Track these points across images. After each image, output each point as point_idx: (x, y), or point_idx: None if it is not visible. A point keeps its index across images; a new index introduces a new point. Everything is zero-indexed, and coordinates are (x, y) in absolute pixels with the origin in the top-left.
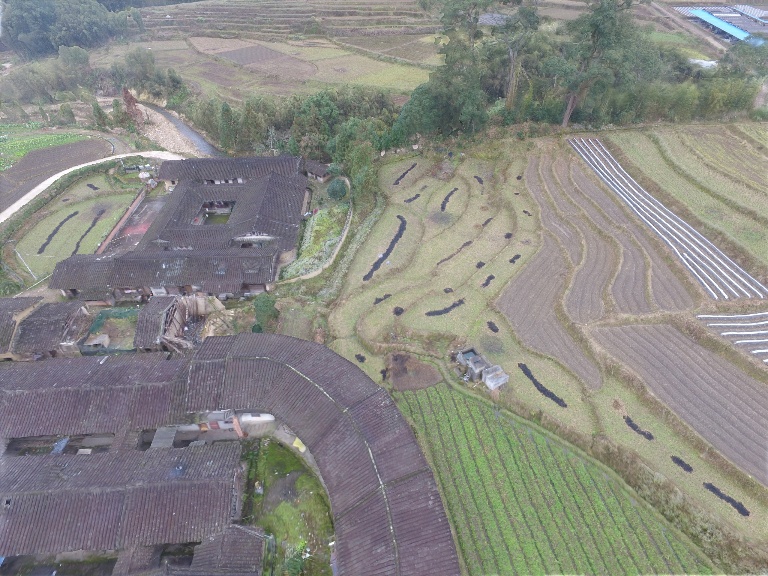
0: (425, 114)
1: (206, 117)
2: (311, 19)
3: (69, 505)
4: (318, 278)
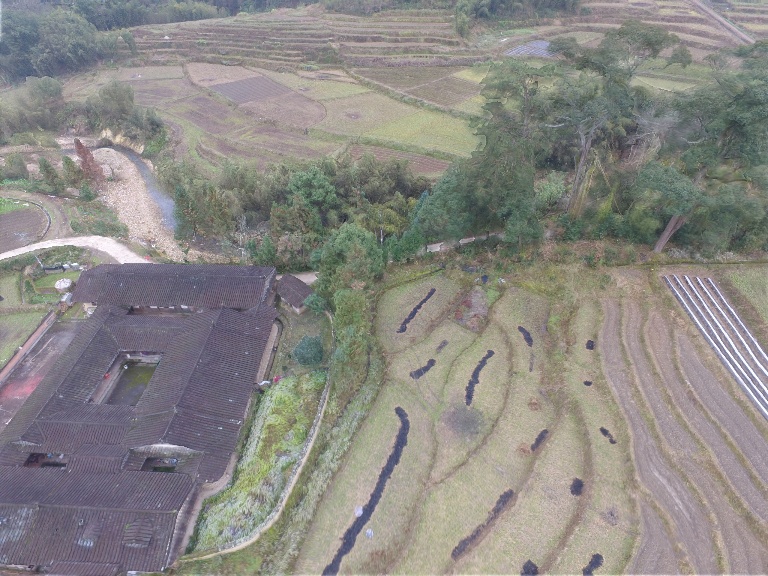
0: (451, 219)
1: (171, 186)
2: (327, 45)
3: None
4: (251, 551)
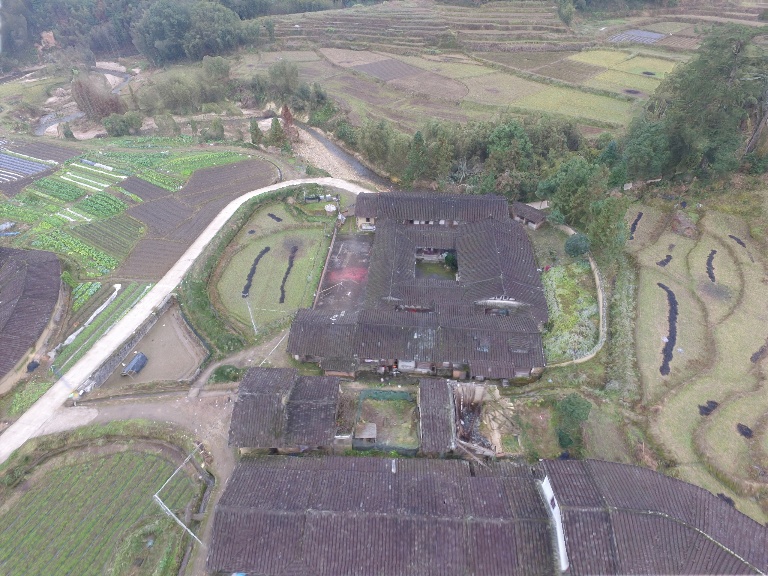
0: (656, 156)
1: (374, 141)
2: (446, 32)
3: None
4: (593, 363)
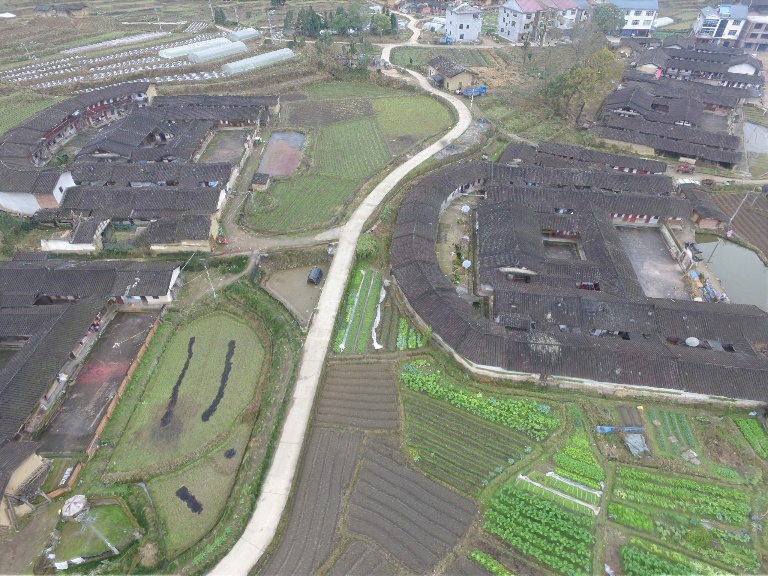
0: None
1: None
2: None
3: None
4: None
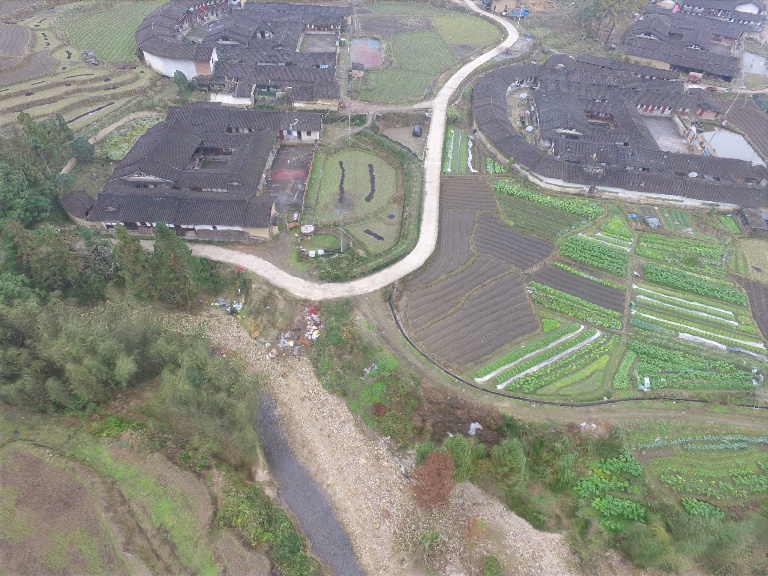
0: None
1: None
2: None
3: None
4: None
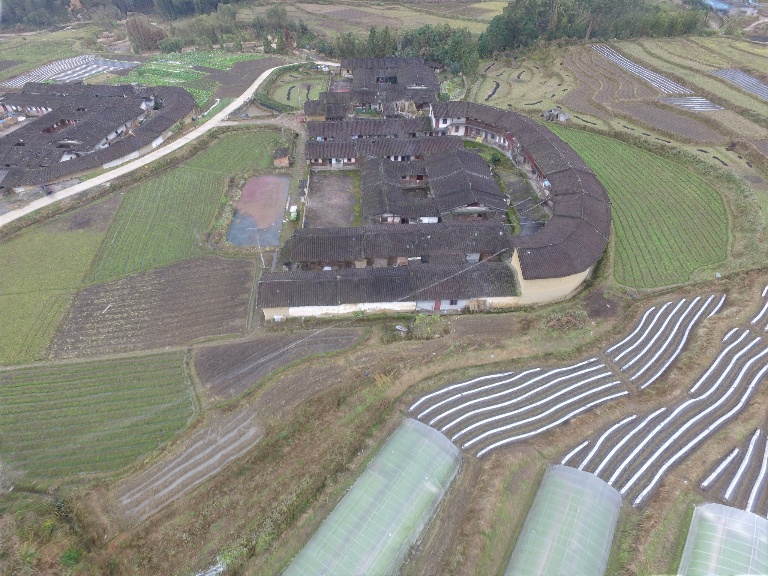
0: (500, 33)
1: (345, 44)
2: None
3: (398, 143)
4: None
